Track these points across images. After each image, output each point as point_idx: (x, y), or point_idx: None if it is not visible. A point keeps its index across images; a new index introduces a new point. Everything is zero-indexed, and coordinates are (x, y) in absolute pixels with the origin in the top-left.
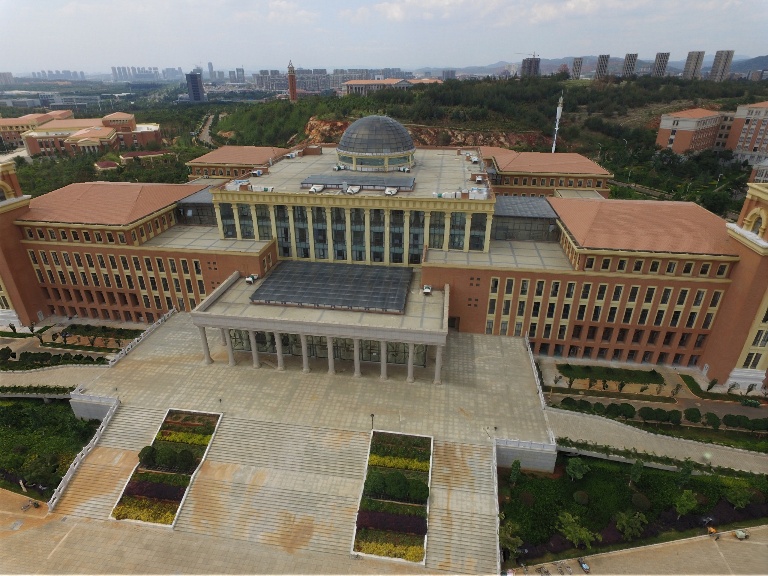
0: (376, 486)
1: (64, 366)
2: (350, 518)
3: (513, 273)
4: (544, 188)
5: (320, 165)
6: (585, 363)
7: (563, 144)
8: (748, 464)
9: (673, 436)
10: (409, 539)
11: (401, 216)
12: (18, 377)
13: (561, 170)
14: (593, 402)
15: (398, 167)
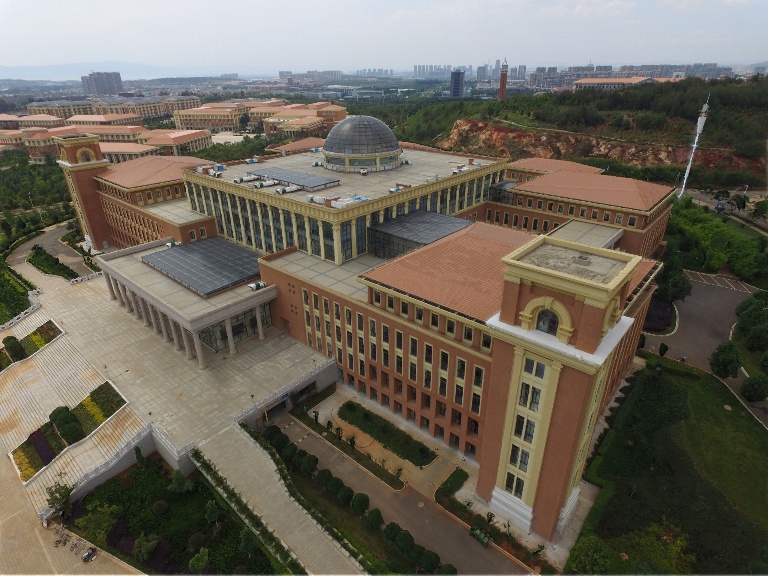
0: (52, 415)
1: (60, 277)
2: (33, 431)
3: (315, 288)
4: (558, 216)
5: (317, 160)
6: (378, 411)
7: (763, 170)
8: None
9: (306, 508)
10: (39, 464)
11: (279, 213)
12: None
13: (584, 196)
14: (320, 447)
15: (360, 169)
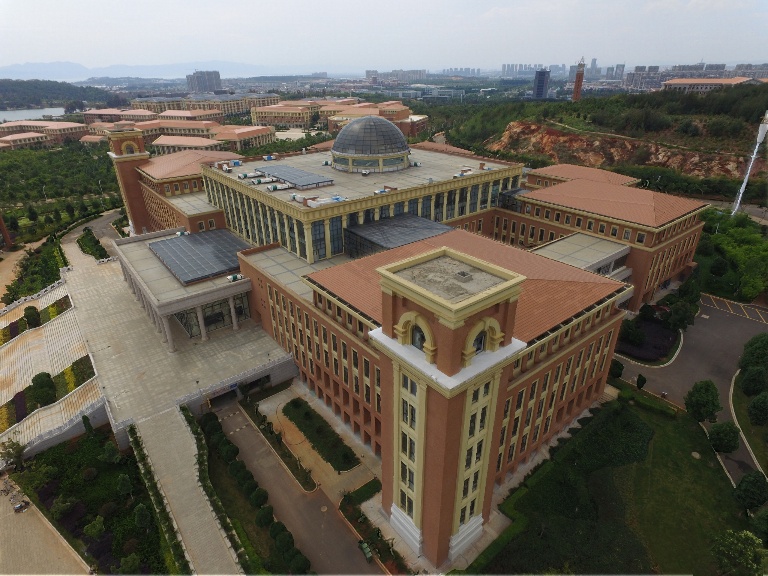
0: None
1: None
2: None
3: None
4: (564, 227)
5: None
6: (322, 411)
7: None
8: (214, 569)
9: (208, 495)
10: (14, 420)
11: None
12: (78, 255)
13: (592, 208)
14: (253, 438)
15: (363, 169)
